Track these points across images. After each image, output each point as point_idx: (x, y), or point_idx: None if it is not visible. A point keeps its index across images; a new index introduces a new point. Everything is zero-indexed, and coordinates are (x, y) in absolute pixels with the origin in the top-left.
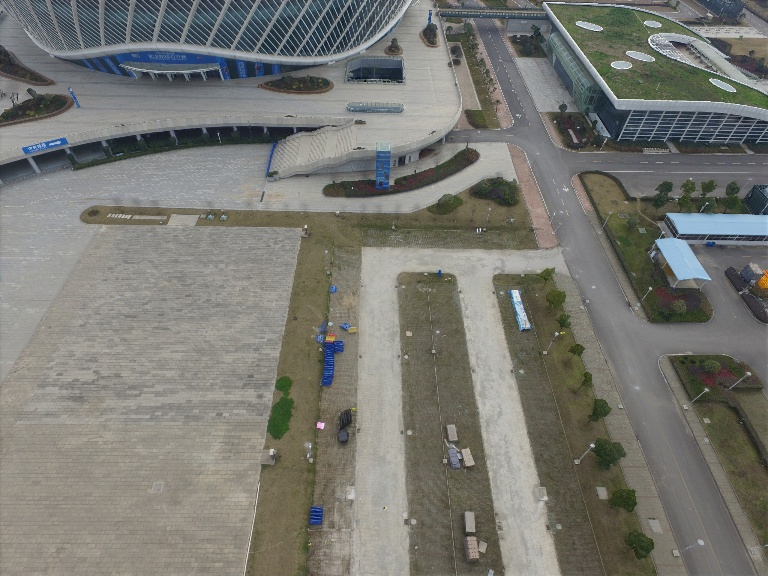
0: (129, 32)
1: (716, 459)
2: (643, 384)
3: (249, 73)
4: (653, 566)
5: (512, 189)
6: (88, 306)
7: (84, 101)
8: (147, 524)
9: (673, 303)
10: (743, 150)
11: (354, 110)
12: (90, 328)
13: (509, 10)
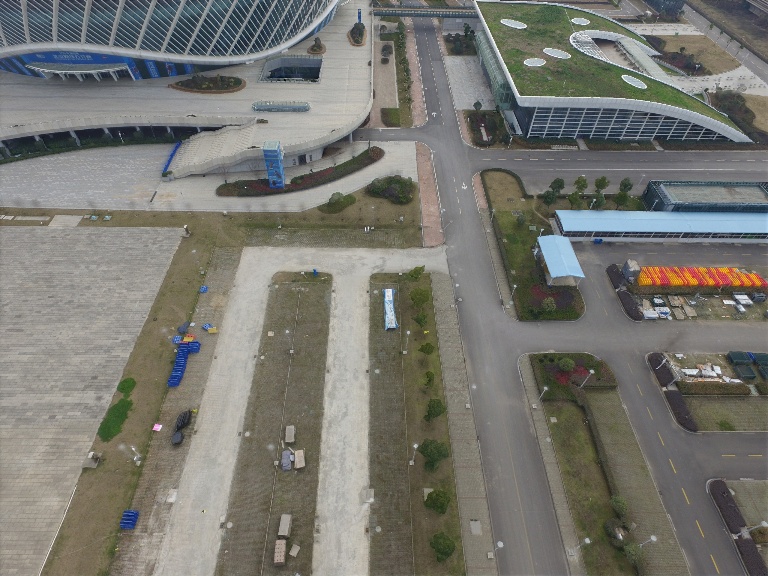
0: (28, 32)
1: (554, 459)
2: (497, 383)
3: (161, 73)
4: (464, 569)
5: (408, 187)
6: None
7: None
8: None
9: (543, 301)
10: (653, 147)
11: (259, 109)
12: None
13: (445, 9)
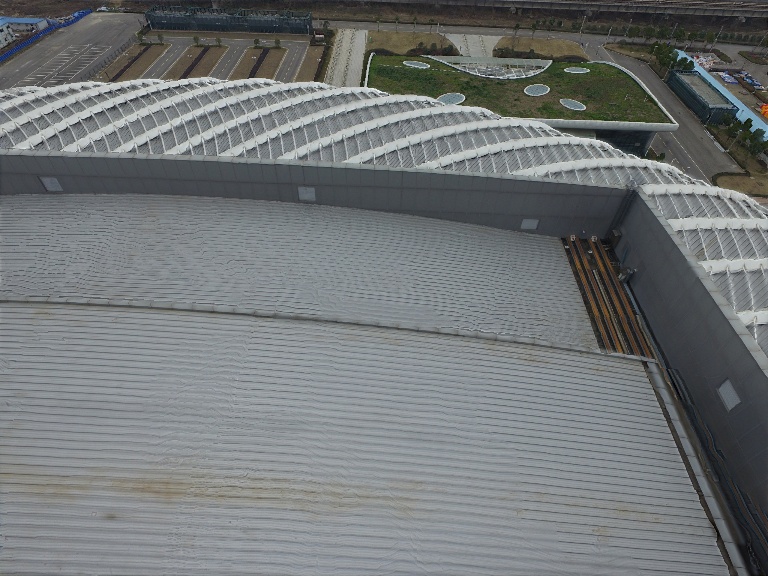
0: None
1: None
2: None
3: None
4: None
5: None
6: None
7: None
8: None
9: None
10: None
11: None
12: None
13: None
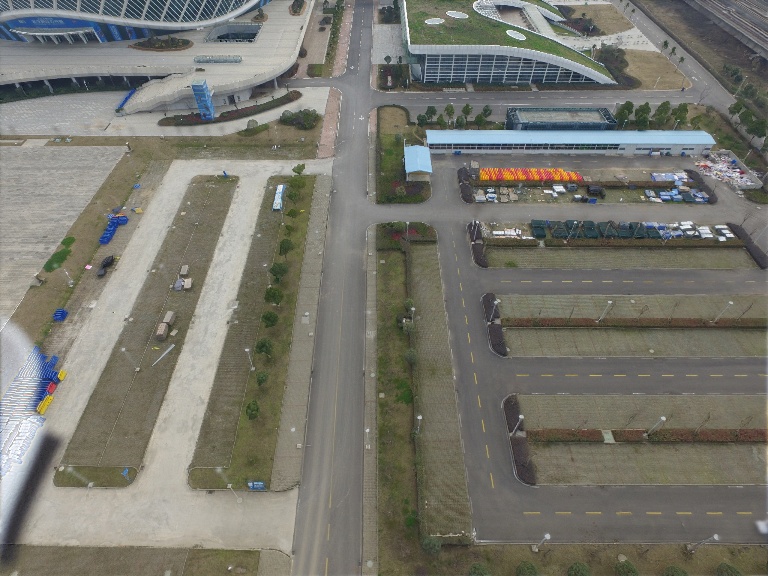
0: (10, 0)
1: (375, 283)
2: (347, 241)
3: (123, 36)
4: (290, 341)
5: (313, 118)
6: None
7: None
8: None
9: (396, 189)
10: (529, 88)
11: (199, 61)
12: None
13: None
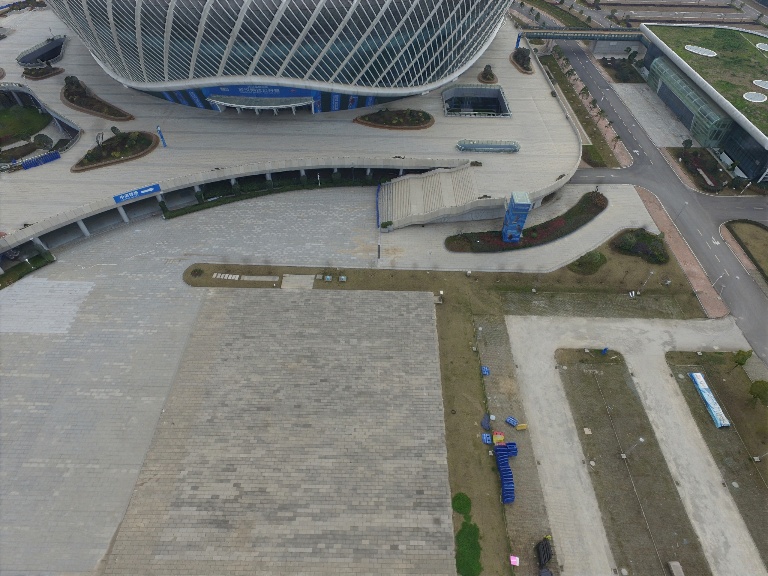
0: (223, 65)
1: None
2: None
3: (341, 106)
4: None
5: None
6: (212, 394)
7: (169, 139)
8: None
9: None
10: None
11: (466, 149)
12: (219, 424)
13: (596, 31)
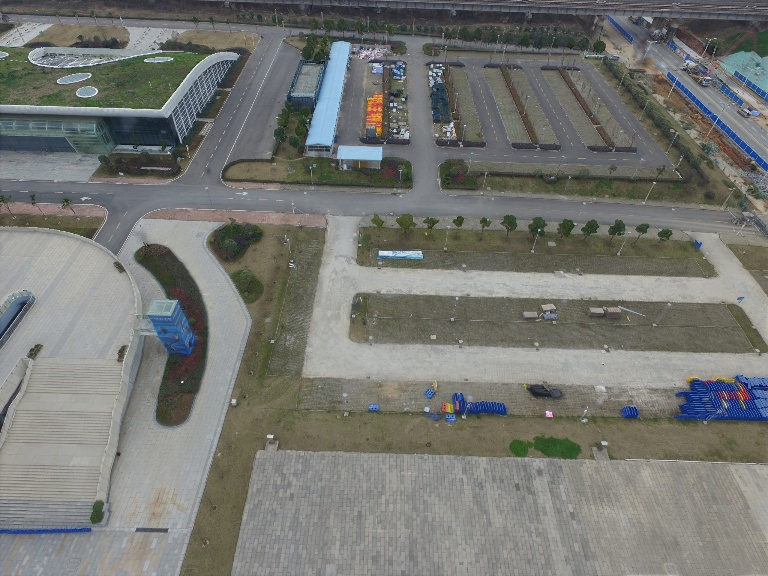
0: None
1: (514, 193)
2: (467, 206)
3: None
4: None
5: (238, 227)
6: None
7: None
8: (708, 570)
9: None
10: (226, 91)
11: None
12: None
13: None
